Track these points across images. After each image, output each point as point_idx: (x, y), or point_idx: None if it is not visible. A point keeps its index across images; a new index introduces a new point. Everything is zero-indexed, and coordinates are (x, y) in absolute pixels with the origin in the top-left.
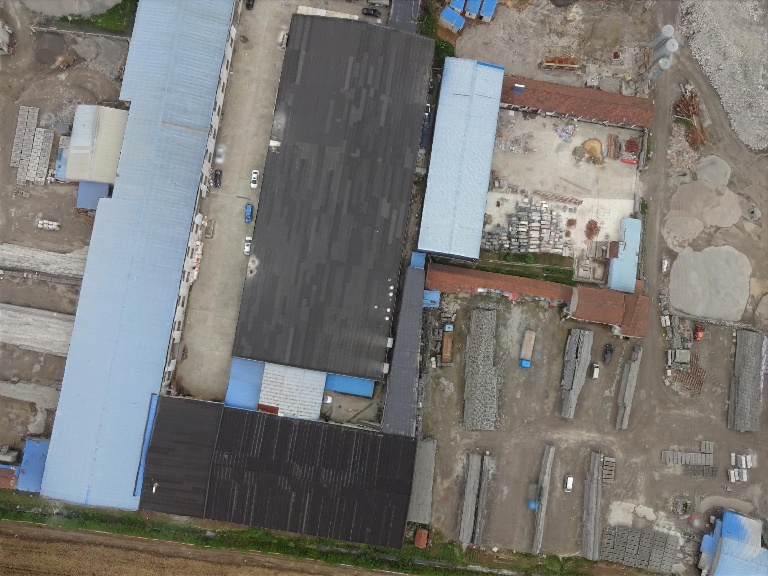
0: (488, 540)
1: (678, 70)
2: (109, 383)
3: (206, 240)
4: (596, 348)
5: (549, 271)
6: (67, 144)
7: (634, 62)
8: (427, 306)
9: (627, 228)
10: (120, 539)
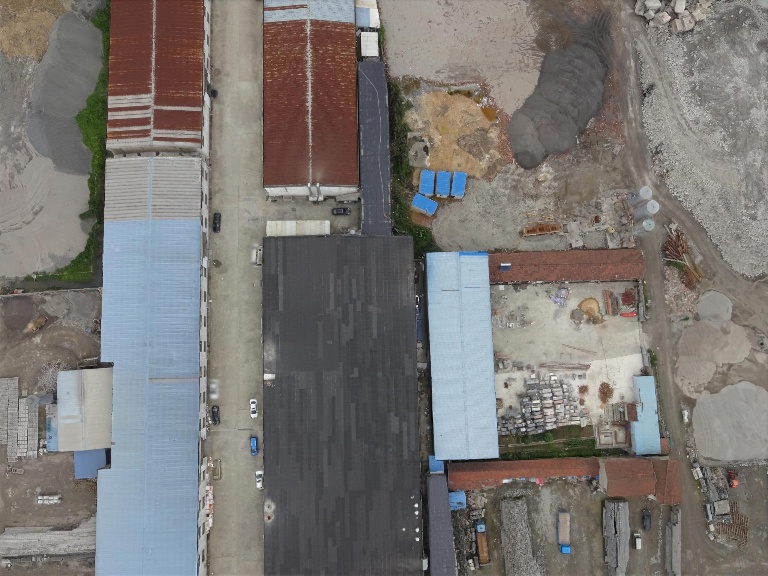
0: None
1: (659, 211)
2: None
3: (215, 482)
4: (633, 515)
5: (570, 445)
6: (54, 412)
7: (614, 212)
8: (454, 509)
9: (641, 388)
10: None
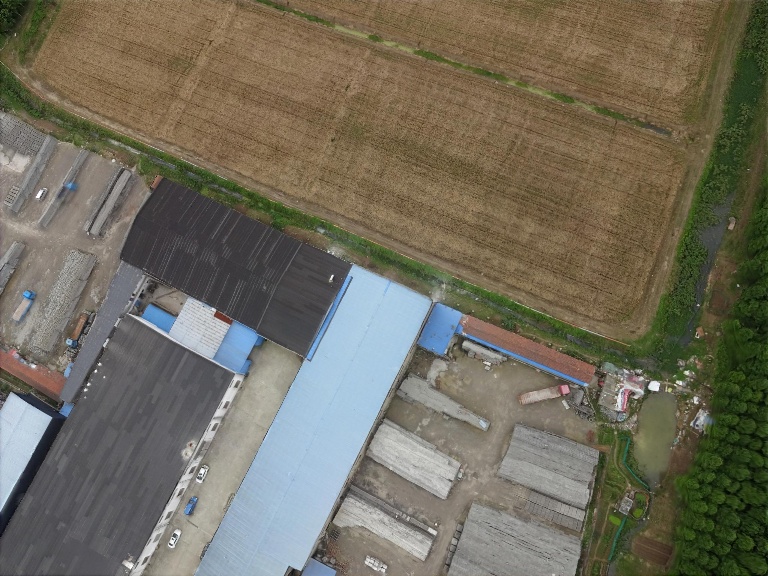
0: None
1: None
2: (340, 382)
3: None
4: None
5: None
6: None
7: None
8: None
9: None
10: (393, 246)
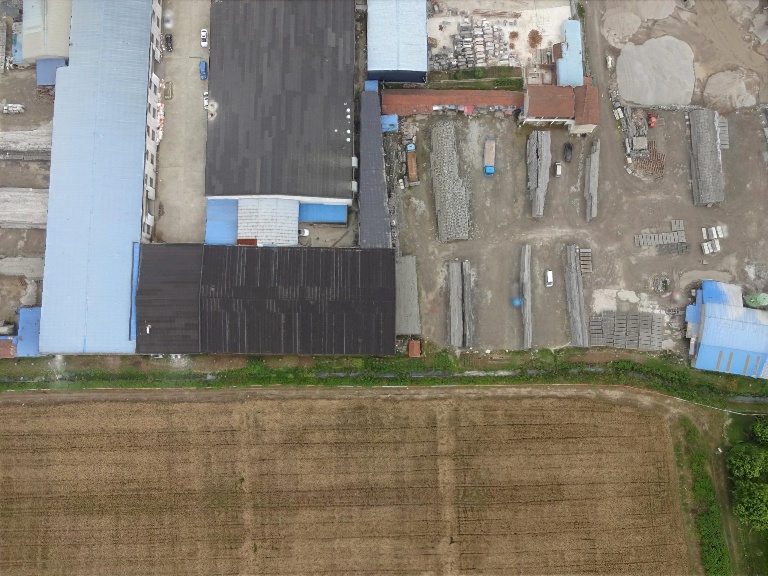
0: (480, 344)
1: None
2: (90, 236)
3: (166, 101)
4: (556, 149)
5: (499, 82)
6: (20, 29)
7: None
8: (387, 130)
9: (567, 29)
10: (124, 393)
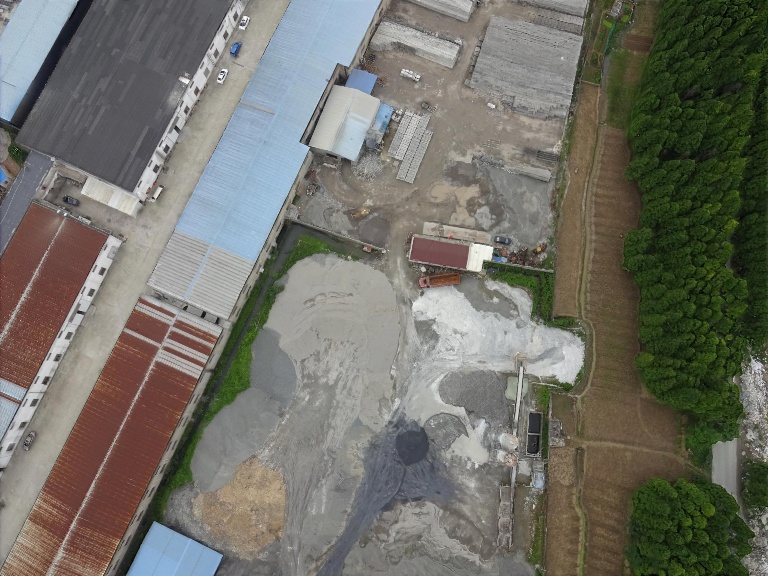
0: None
1: None
2: None
3: None
4: None
5: None
6: None
7: None
8: None
9: None
10: None
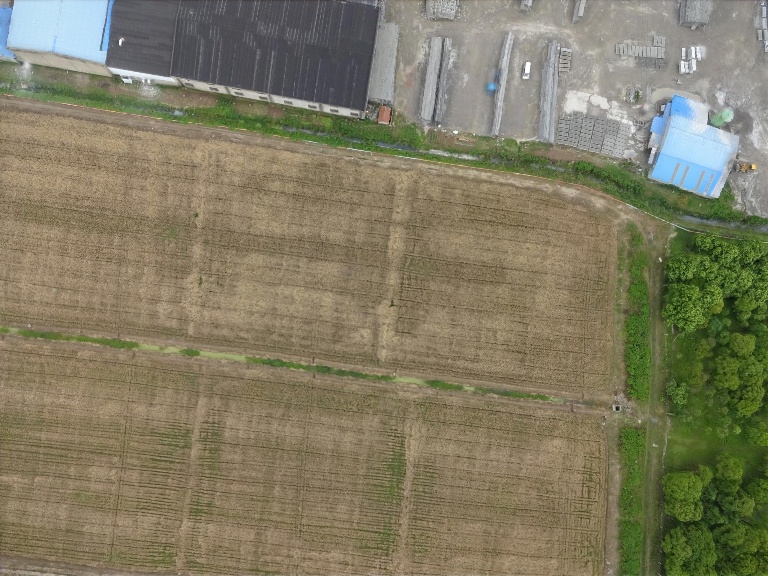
0: (449, 123)
1: None
2: None
3: None
4: None
5: None
6: None
7: None
8: None
9: None
10: (89, 112)
